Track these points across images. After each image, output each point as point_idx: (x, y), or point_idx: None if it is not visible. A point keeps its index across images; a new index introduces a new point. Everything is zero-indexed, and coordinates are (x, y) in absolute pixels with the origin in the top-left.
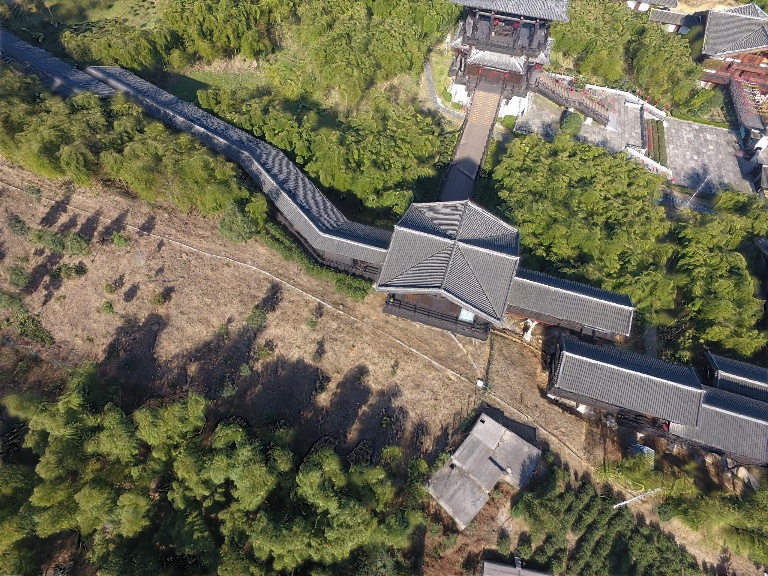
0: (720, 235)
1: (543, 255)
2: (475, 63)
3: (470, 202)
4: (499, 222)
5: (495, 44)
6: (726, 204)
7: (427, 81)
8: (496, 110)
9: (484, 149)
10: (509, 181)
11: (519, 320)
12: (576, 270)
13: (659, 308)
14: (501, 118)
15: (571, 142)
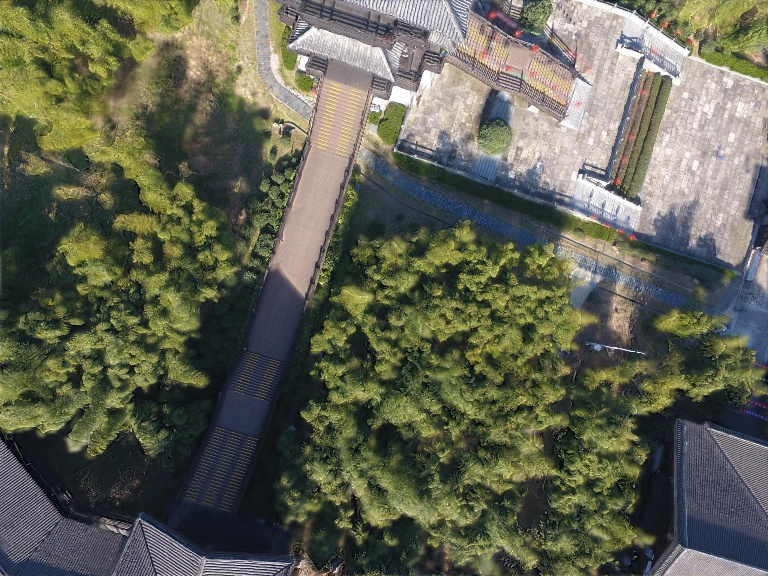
0: (624, 435)
1: (348, 527)
2: (306, 50)
3: (207, 559)
4: (259, 563)
5: (335, 24)
6: (674, 333)
7: (255, 2)
8: (358, 129)
9: (329, 223)
10: (325, 382)
11: (322, 570)
12: (379, 573)
13: (525, 483)
14: (379, 114)
15: (456, 252)
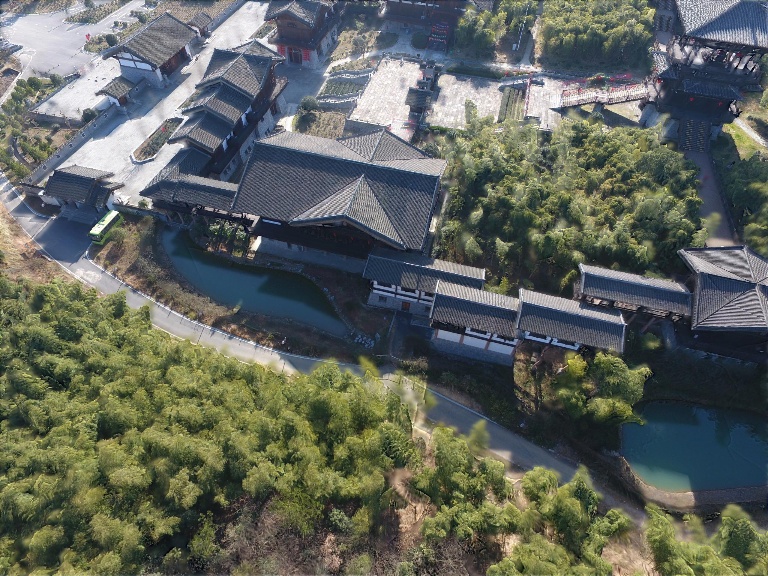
0: None
1: None
2: None
3: None
4: None
5: None
6: None
7: (745, 125)
8: None
9: None
10: None
11: None
12: None
13: None
14: None
15: None
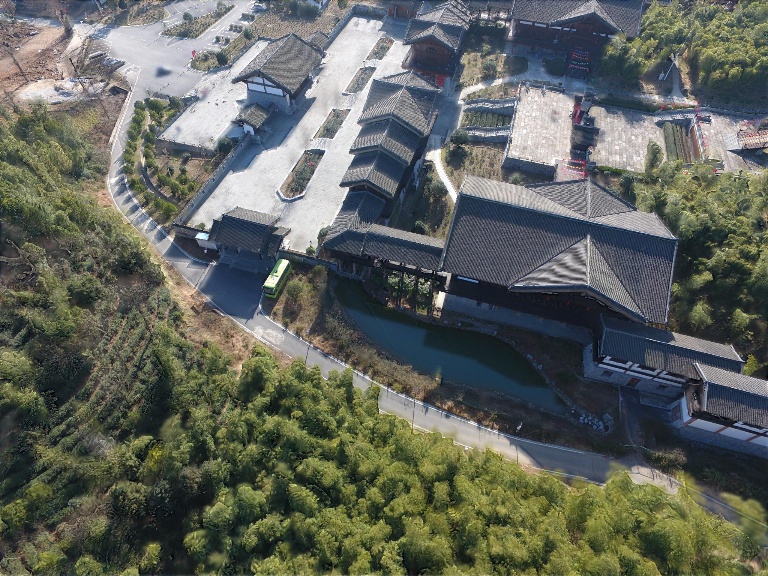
0: None
1: None
2: None
3: None
4: None
5: None
6: None
7: None
8: None
9: None
10: None
11: None
12: None
13: None
14: None
15: None
